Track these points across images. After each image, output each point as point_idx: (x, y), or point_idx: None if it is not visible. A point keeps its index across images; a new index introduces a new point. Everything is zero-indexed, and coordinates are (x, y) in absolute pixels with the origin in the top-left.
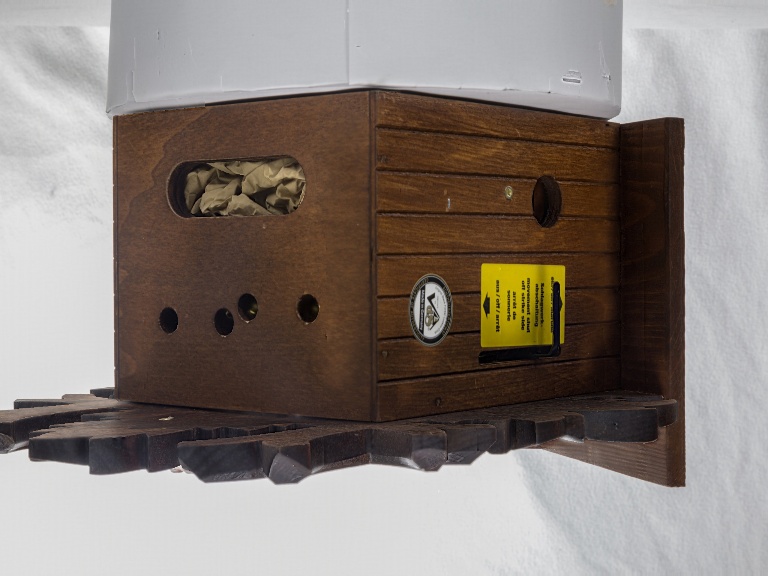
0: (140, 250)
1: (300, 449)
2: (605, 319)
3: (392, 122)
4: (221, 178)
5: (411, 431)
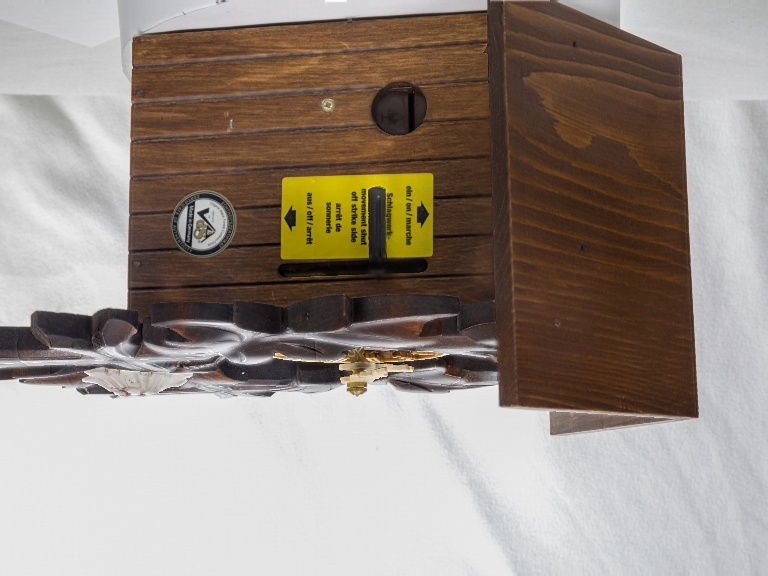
0: None
1: None
2: None
3: (152, 60)
4: None
5: None
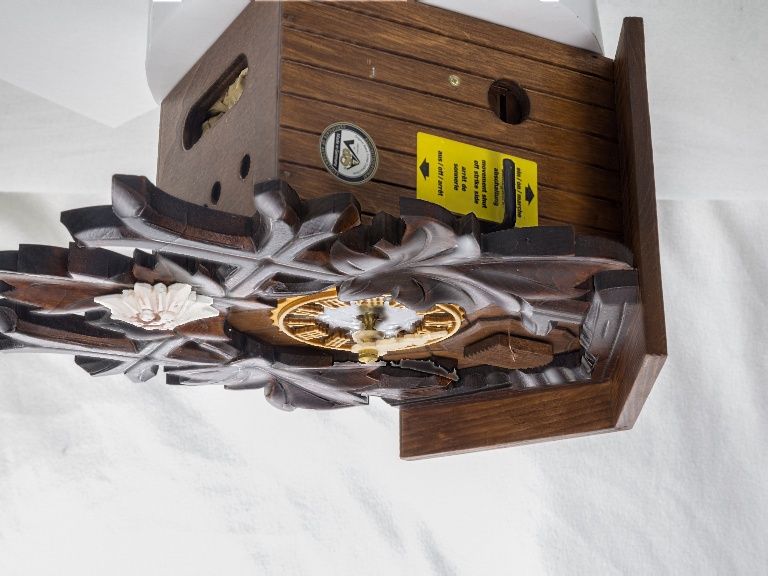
0: None
1: (134, 178)
2: (600, 226)
3: None
4: None
5: None
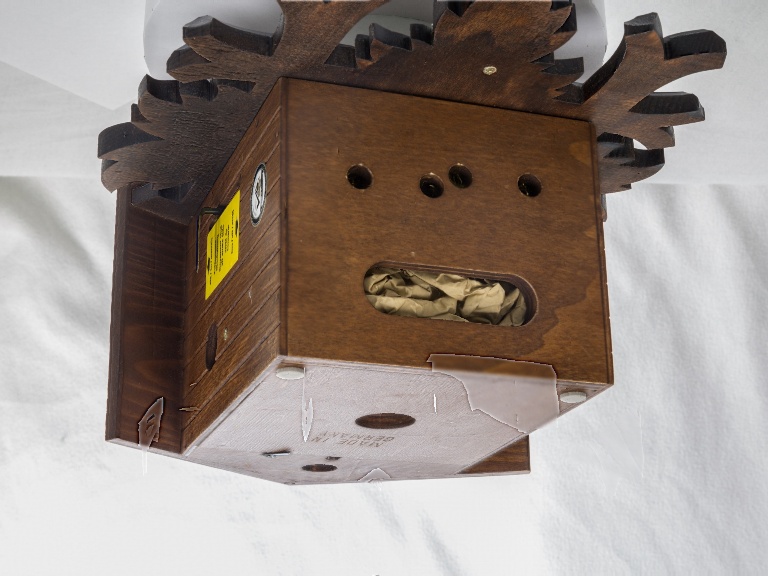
0: (570, 252)
1: None
2: None
3: None
4: (487, 321)
5: (225, 50)
